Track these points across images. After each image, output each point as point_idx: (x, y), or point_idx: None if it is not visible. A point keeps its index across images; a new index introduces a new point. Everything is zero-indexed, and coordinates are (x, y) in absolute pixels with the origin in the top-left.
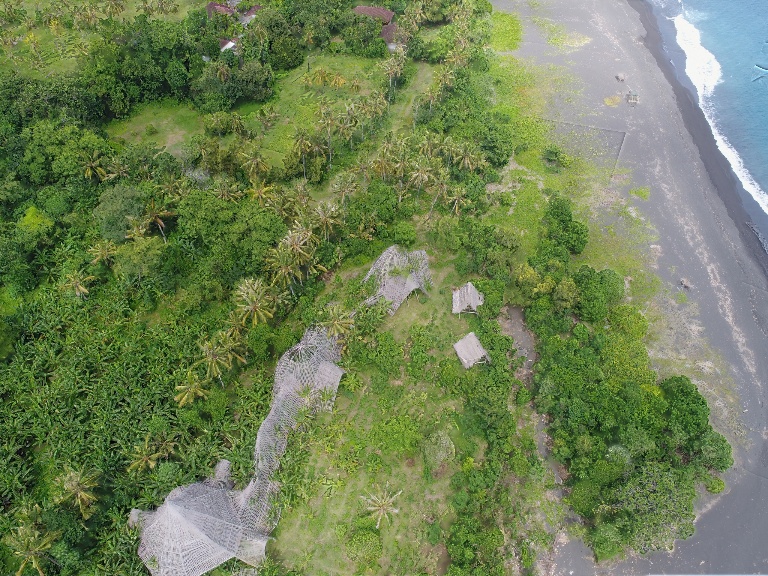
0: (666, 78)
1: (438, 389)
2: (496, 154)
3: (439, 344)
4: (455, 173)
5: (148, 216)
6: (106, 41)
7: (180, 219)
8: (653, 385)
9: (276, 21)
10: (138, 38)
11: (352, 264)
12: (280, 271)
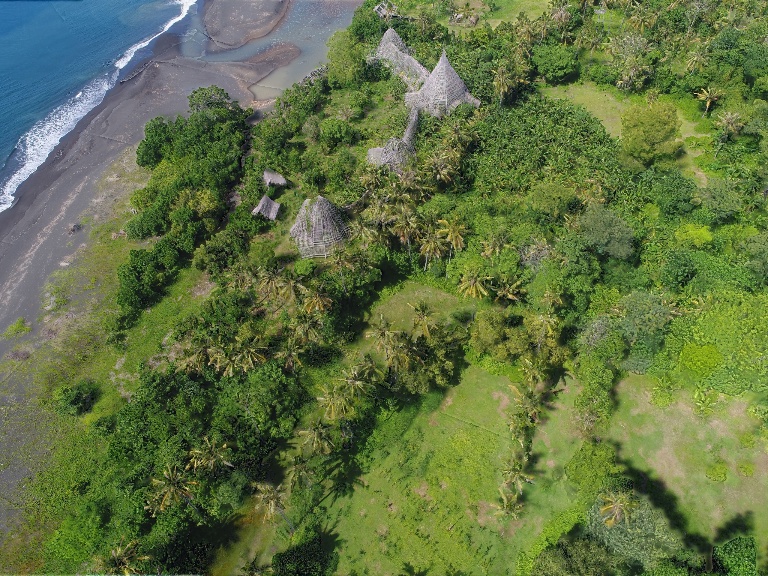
0: None
1: None
2: None
3: (297, 193)
4: None
5: None
6: None
7: None
8: None
9: None
10: None
11: None
12: None
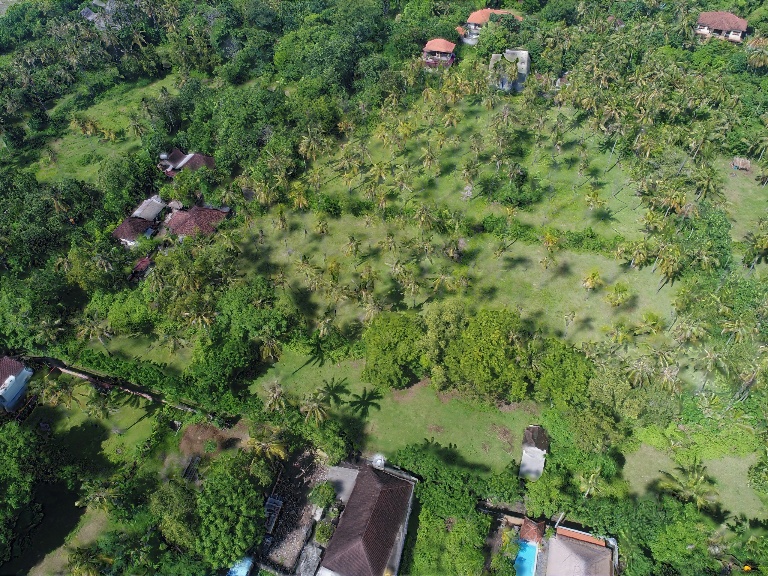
0: None
1: None
2: None
3: None
4: None
5: None
6: None
7: None
8: None
9: None
10: None
11: None
12: None
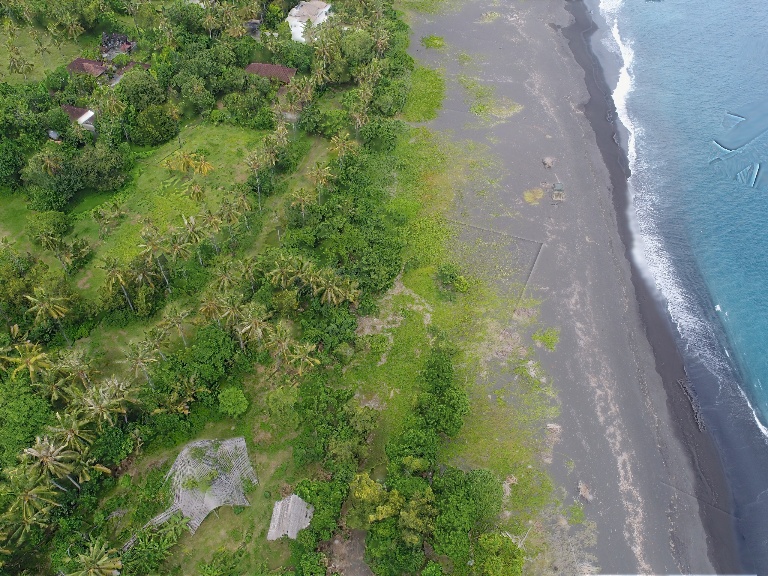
0: (604, 161)
1: None
2: None
3: None
4: (316, 308)
5: None
6: None
7: None
8: None
9: (144, 86)
10: None
11: (161, 445)
12: (18, 498)
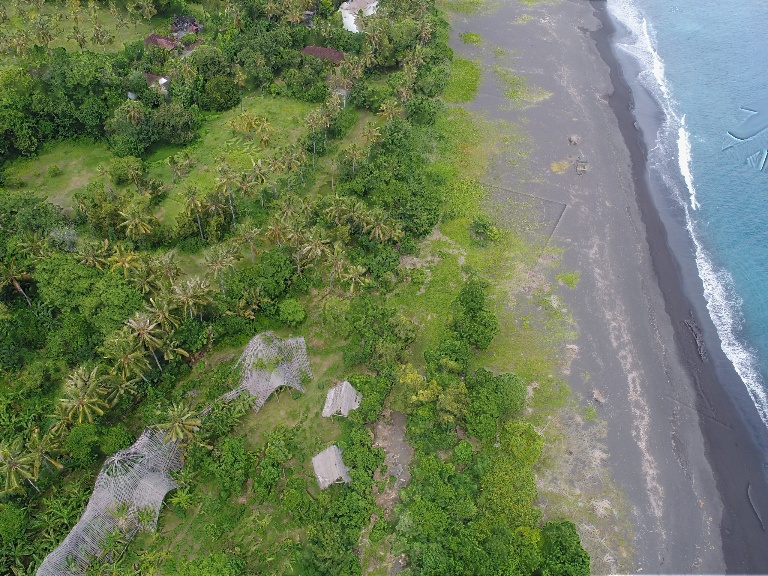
0: (625, 143)
1: (286, 512)
2: (416, 223)
3: (300, 453)
4: (364, 243)
5: (3, 278)
6: (21, 73)
7: (40, 283)
8: (534, 528)
9: (212, 59)
10: (52, 72)
11: (229, 344)
12: (119, 360)
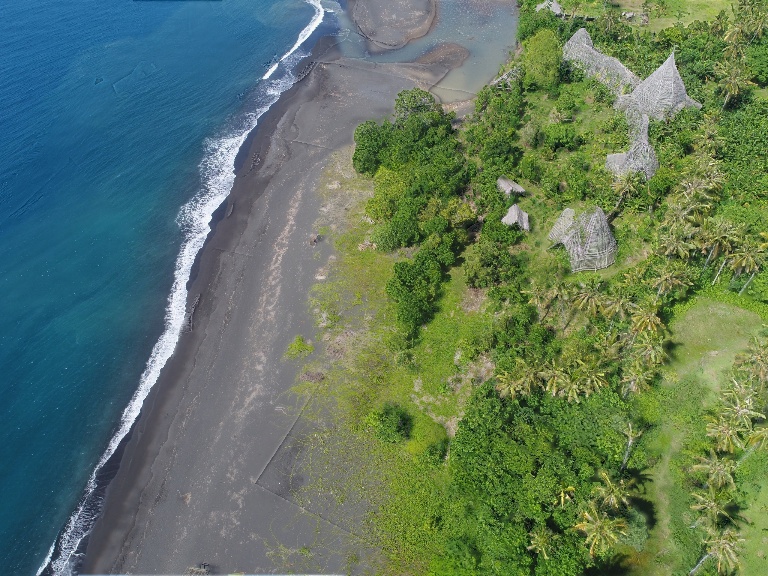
0: None
1: None
2: None
3: None
4: None
5: None
6: None
7: None
8: None
9: None
10: None
11: None
12: None
